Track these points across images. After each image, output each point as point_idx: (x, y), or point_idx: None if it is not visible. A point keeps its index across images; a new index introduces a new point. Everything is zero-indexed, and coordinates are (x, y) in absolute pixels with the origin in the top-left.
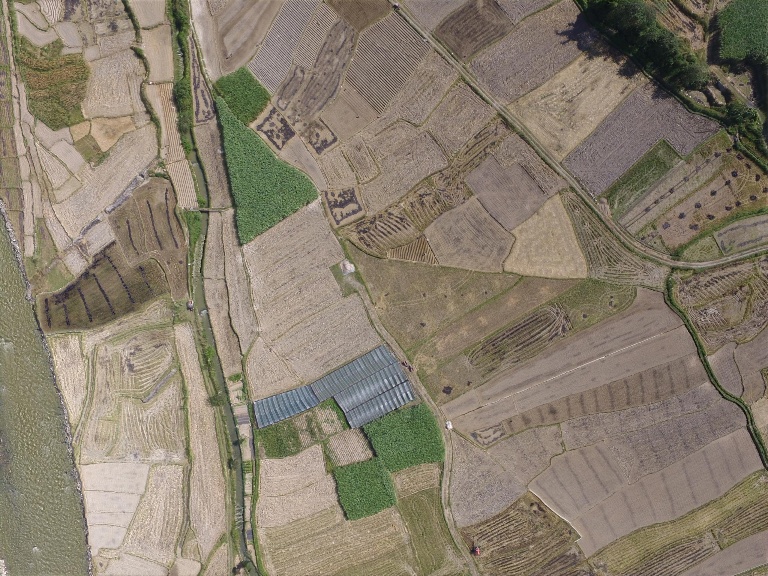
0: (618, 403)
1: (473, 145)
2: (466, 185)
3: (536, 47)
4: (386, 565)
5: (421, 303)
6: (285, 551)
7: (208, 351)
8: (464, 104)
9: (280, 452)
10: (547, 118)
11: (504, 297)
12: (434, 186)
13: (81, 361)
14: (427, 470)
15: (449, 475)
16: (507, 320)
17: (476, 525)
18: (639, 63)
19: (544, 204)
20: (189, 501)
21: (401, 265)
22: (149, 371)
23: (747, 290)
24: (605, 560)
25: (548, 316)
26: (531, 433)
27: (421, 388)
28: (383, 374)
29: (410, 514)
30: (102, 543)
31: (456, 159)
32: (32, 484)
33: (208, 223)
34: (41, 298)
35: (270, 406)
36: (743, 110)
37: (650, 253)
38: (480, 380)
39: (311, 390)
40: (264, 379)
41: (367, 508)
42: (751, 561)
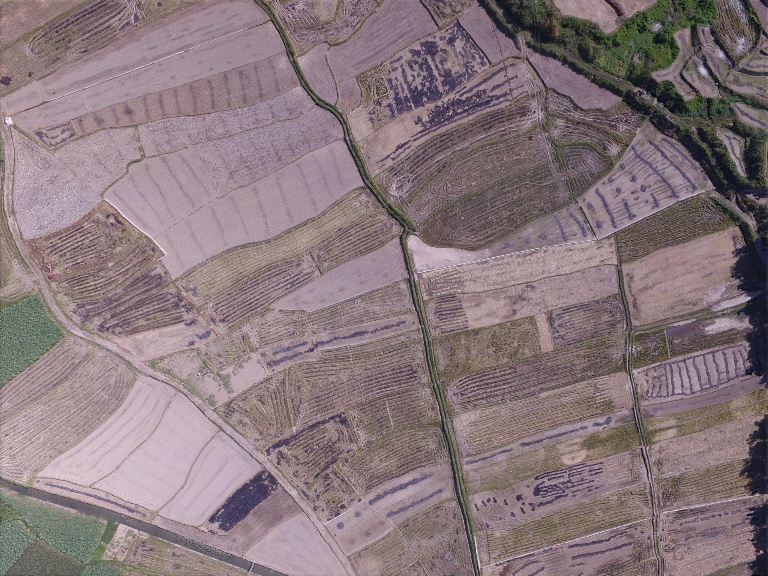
0: (202, 106)
1: None
2: None
3: None
4: None
5: None
6: None
7: None
8: None
9: None
10: None
11: None
12: None
13: None
14: None
15: (11, 178)
16: (71, 3)
17: (46, 237)
18: None
19: None
20: None
21: None
22: None
23: None
24: (195, 283)
25: (118, 2)
26: (104, 135)
27: None
28: None
29: None
30: None
31: None
32: None
33: None
34: None
35: None
36: None
37: None
38: (43, 71)
39: None
40: None
41: None
42: (354, 288)
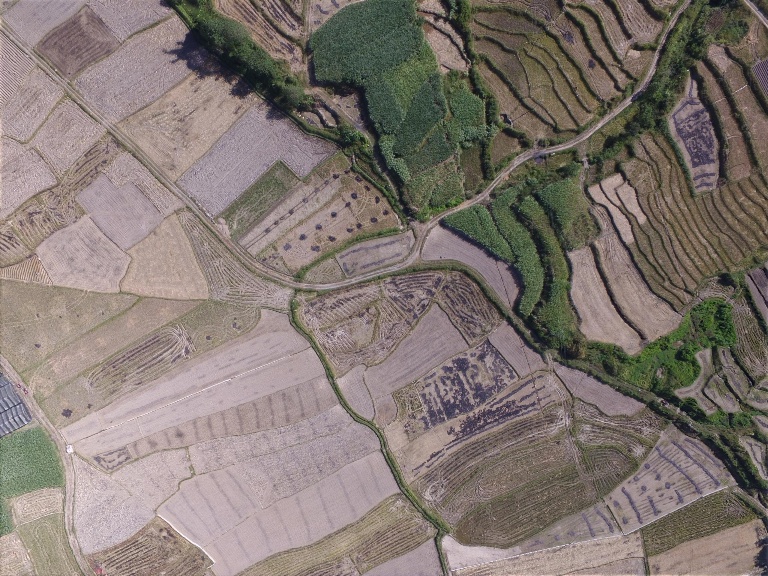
0: (248, 426)
1: (84, 163)
2: (77, 204)
3: (144, 65)
4: None
5: (35, 324)
6: None
7: None
8: (72, 121)
9: None
10: (159, 137)
11: (123, 318)
12: (44, 204)
13: None
14: (49, 495)
15: (72, 500)
16: (127, 341)
17: (103, 552)
18: (250, 83)
19: (161, 224)
20: None
21: (11, 285)
22: None
23: (374, 312)
24: None
25: (170, 338)
26: (157, 457)
27: (38, 411)
28: None
29: (33, 541)
30: None
31: (66, 177)
32: None
33: None
34: None
35: None
36: (348, 132)
37: (272, 274)
38: (101, 403)
39: None
40: None
41: None
42: None
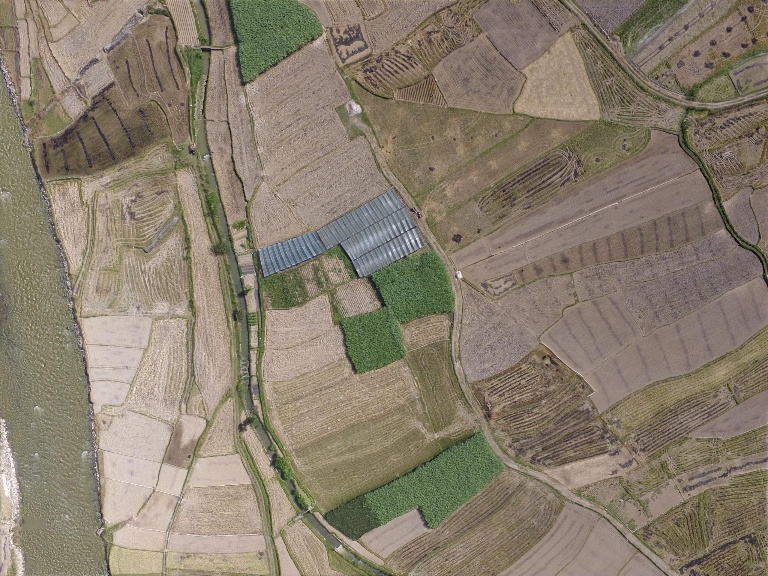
0: (632, 252)
1: None
2: (475, 22)
3: None
4: (395, 421)
5: (429, 146)
6: (292, 406)
7: (211, 196)
8: None
9: (286, 302)
10: None
11: (515, 140)
12: (442, 23)
13: (81, 209)
14: (437, 322)
15: (459, 327)
16: (518, 164)
17: (487, 379)
18: None
19: (555, 42)
20: (193, 355)
21: (409, 106)
22: (151, 219)
23: (764, 132)
24: (619, 416)
25: (560, 160)
26: (543, 283)
27: (430, 236)
28: (391, 220)
29: (420, 368)
30: (105, 400)
31: None
32: (32, 340)
33: (210, 62)
34: (39, 142)
35: (275, 253)
36: None
37: (664, 93)
38: (490, 227)
39: (317, 236)
40: (269, 226)
41: (376, 359)
42: (767, 416)
